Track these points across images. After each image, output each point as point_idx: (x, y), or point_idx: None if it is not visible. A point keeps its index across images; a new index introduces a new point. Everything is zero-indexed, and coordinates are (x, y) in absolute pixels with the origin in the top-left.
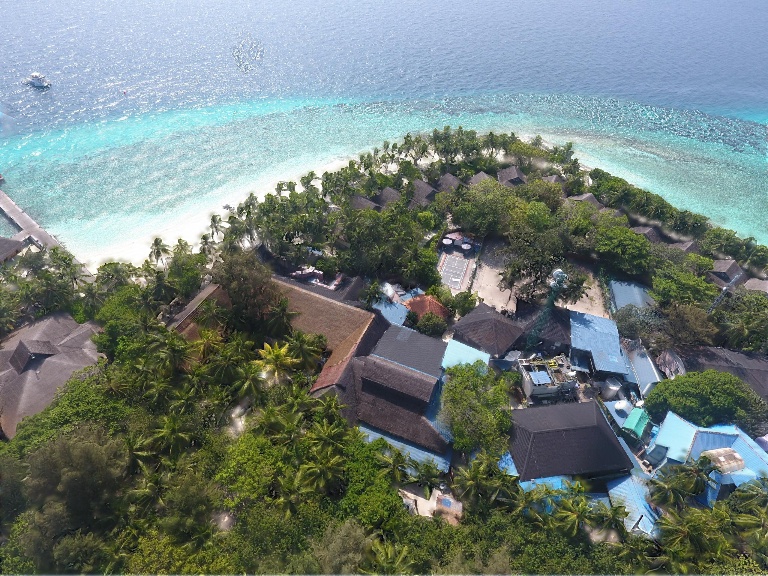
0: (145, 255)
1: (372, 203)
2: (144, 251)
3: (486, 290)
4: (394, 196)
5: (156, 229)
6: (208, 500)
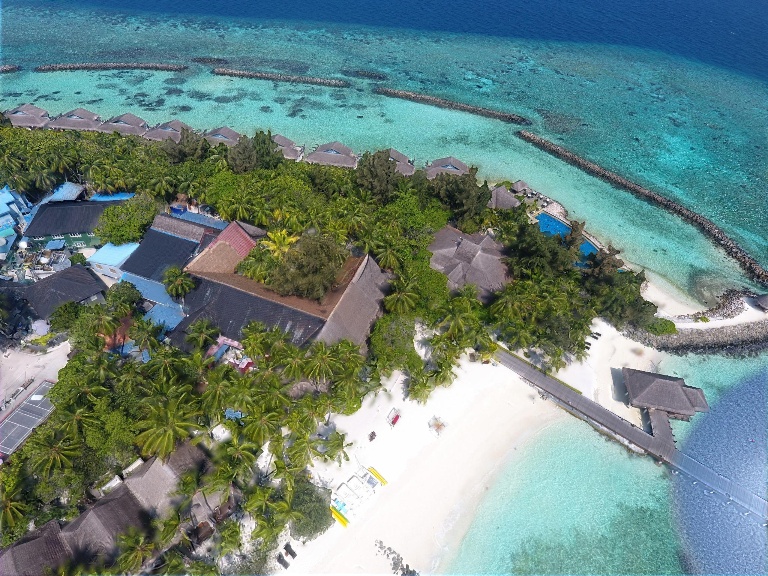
0: (478, 414)
1: (96, 518)
2: (486, 425)
3: (6, 382)
4: (27, 566)
5: (504, 489)
6: (311, 179)
